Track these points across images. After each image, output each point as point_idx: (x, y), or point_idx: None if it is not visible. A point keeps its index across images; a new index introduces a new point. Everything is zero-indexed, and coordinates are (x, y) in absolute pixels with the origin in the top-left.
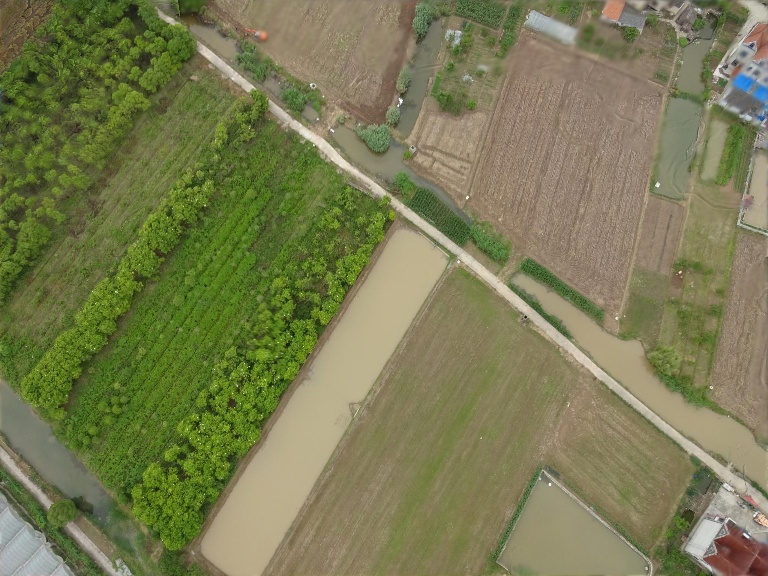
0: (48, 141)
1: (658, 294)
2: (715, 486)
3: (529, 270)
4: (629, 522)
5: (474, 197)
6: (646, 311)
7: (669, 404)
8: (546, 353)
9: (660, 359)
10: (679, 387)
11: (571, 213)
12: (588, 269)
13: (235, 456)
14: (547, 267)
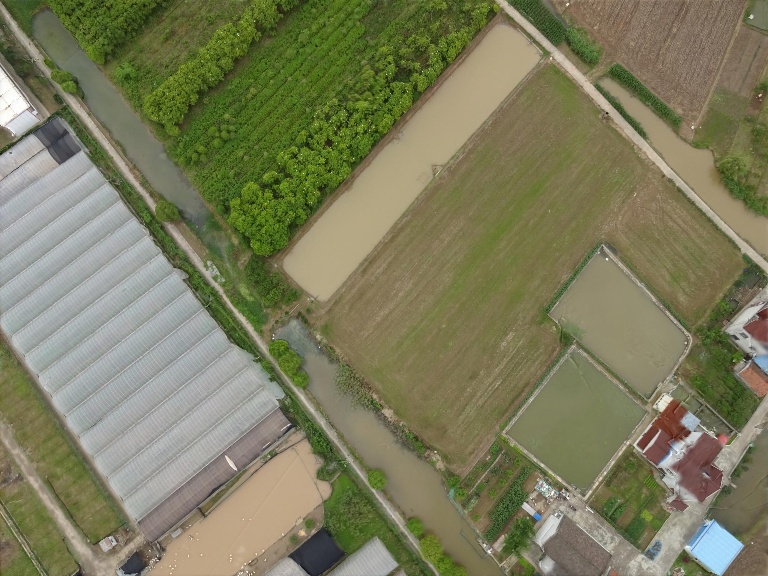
0: None
1: (735, 112)
2: (762, 282)
3: (616, 74)
4: (676, 301)
5: (574, 5)
6: (721, 126)
7: (730, 208)
8: (621, 148)
9: (729, 162)
10: (742, 193)
11: (664, 31)
12: (672, 81)
13: (325, 189)
14: (634, 74)
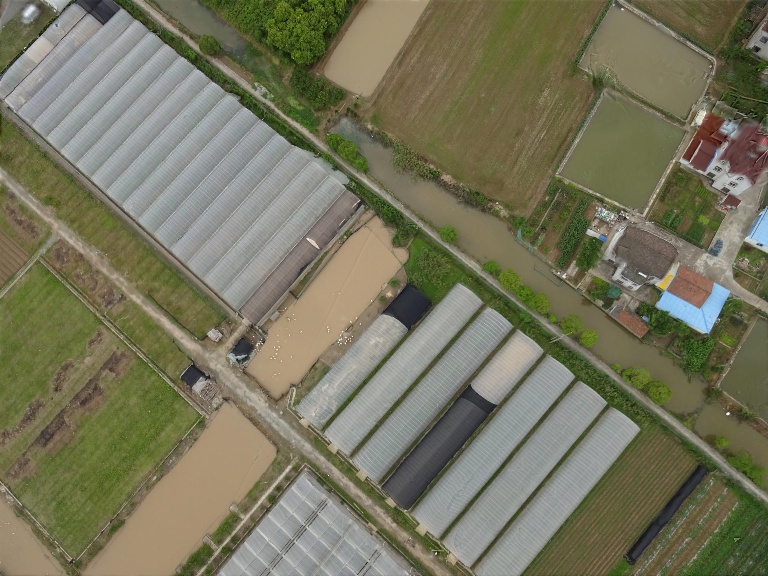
0: None
1: None
2: None
3: None
4: (694, 32)
5: None
6: None
7: None
8: None
9: None
10: None
11: None
12: None
13: None
14: None
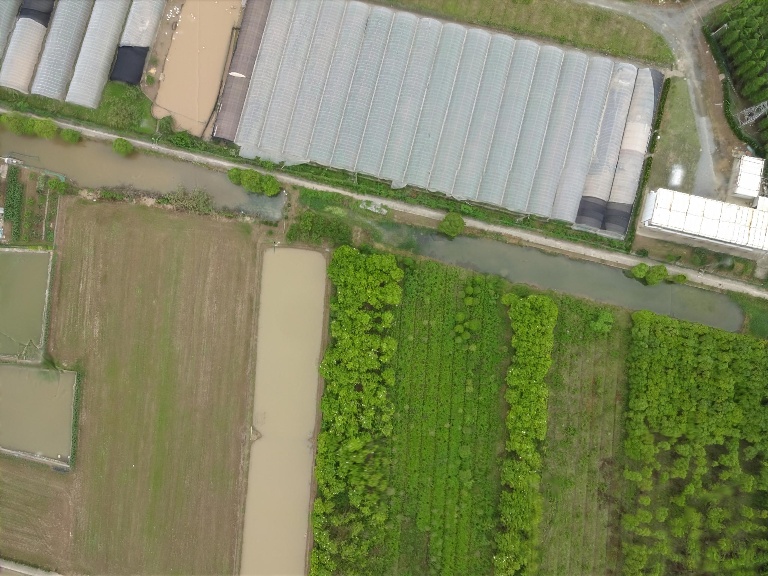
0: (677, 557)
1: None
2: None
3: None
4: None
5: None
6: None
7: None
8: (109, 572)
9: None
10: None
11: None
12: None
13: (333, 344)
14: None
